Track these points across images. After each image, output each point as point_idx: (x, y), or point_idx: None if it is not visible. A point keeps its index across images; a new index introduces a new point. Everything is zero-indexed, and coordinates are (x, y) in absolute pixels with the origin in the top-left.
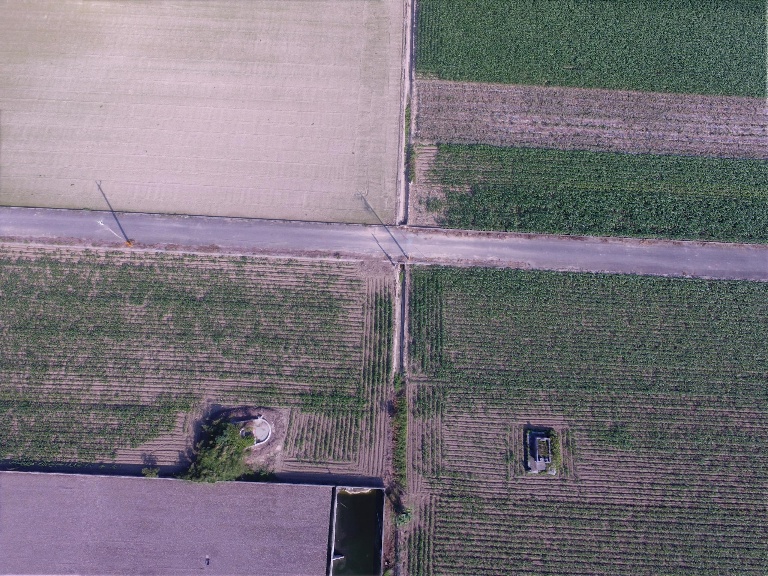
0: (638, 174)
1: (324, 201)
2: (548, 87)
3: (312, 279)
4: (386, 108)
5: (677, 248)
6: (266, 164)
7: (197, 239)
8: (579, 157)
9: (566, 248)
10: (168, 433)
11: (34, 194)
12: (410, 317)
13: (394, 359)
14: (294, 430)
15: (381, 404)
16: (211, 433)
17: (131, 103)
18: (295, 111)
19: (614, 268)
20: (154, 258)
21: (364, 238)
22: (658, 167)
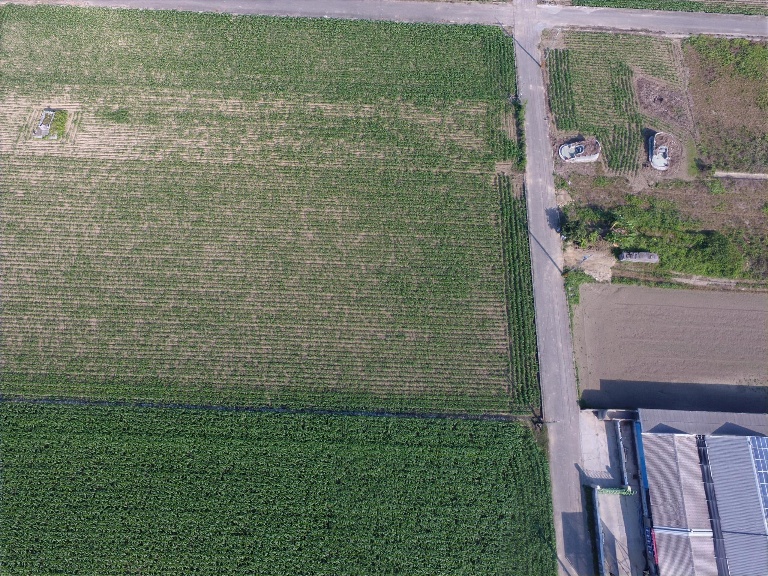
0: None
1: None
2: None
3: None
4: None
5: None
6: None
7: None
8: None
9: None
10: None
11: None
12: None
13: None
14: None
15: None
16: None
17: None
18: None
19: (159, 6)
20: None
21: None
22: None
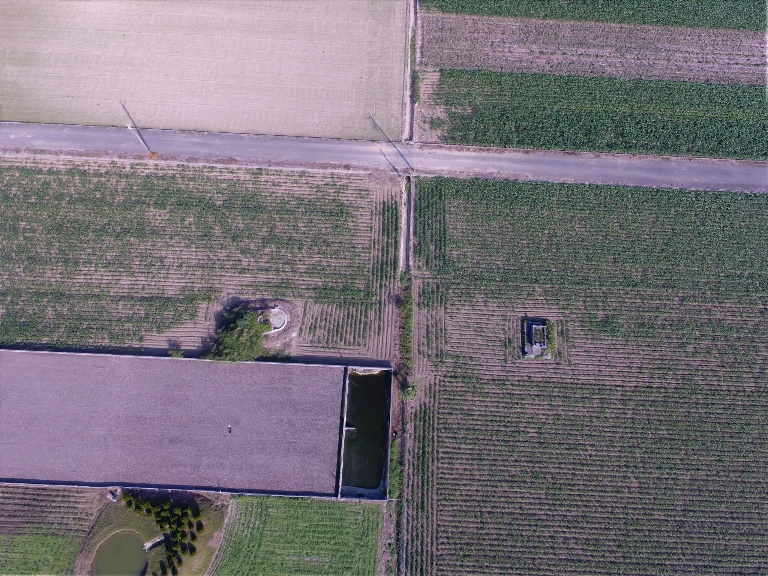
0: (629, 97)
1: (334, 120)
2: (545, 20)
3: (324, 189)
4: (392, 38)
5: (665, 163)
6: (280, 87)
7: (216, 152)
8: (574, 82)
9: (561, 162)
10: (191, 321)
11: (63, 112)
12: (415, 222)
13: (401, 259)
14: (308, 320)
15: (389, 298)
16: (232, 318)
17: (152, 32)
18: (306, 40)
19: (606, 180)
20: (176, 169)
21: (372, 152)
22: (648, 91)
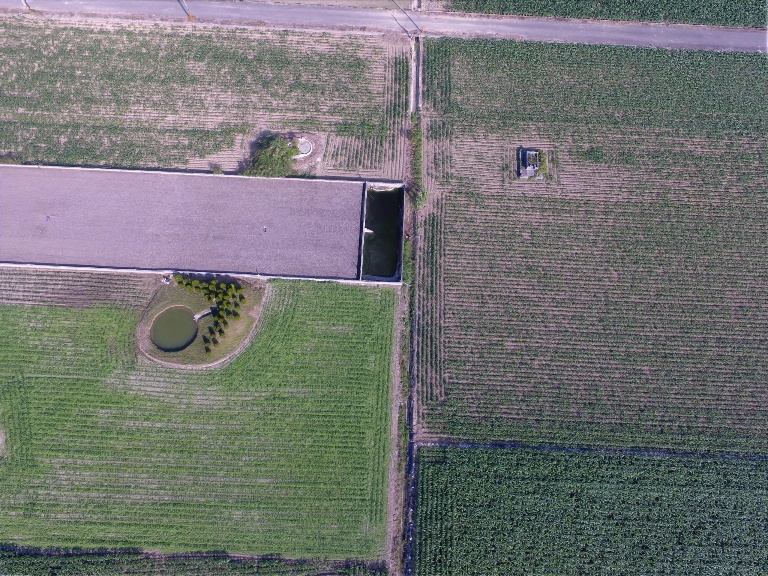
0: None
1: None
2: None
3: (342, 47)
4: None
5: (645, 27)
6: None
7: (247, 16)
8: None
9: (553, 26)
10: (229, 149)
11: None
12: (424, 73)
13: (411, 102)
14: (331, 149)
15: (401, 132)
16: (265, 142)
17: None
18: None
19: (592, 40)
20: (212, 31)
21: (385, 17)
22: None
